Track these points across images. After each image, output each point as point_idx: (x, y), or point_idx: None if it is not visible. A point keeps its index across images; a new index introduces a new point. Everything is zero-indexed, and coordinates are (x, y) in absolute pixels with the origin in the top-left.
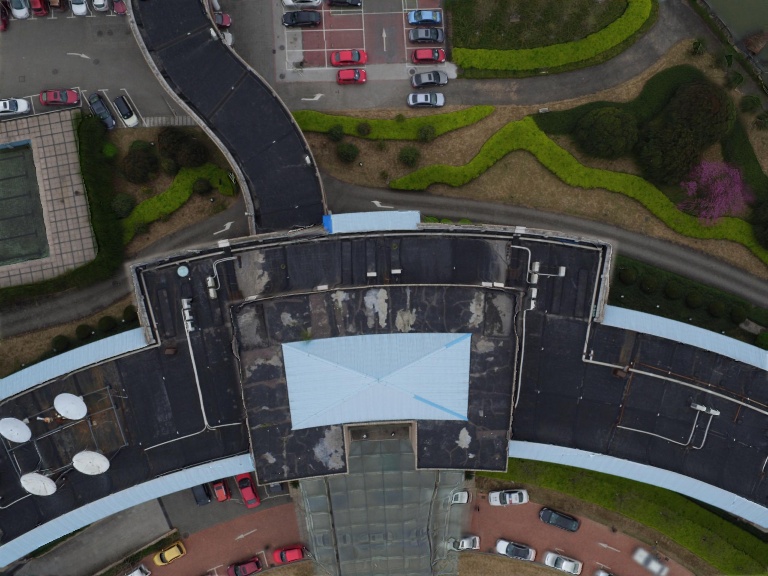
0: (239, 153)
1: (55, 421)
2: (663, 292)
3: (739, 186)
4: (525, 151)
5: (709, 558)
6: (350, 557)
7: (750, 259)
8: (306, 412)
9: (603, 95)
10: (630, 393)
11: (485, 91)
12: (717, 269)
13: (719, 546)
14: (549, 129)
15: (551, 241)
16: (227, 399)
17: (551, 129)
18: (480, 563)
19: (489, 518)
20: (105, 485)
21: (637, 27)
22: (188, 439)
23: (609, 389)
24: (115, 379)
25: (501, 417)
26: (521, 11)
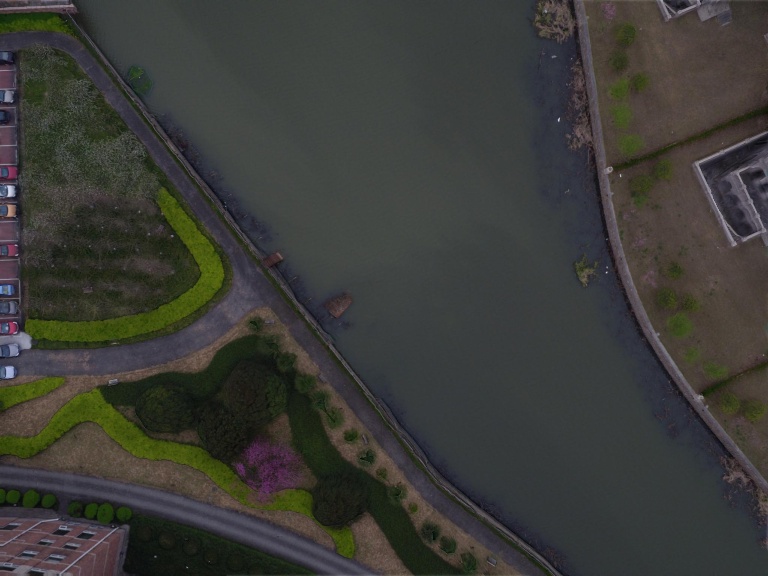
0: None
1: None
2: (226, 563)
3: (299, 461)
4: (94, 422)
5: None
6: None
7: (316, 529)
8: None
9: (174, 365)
10: None
11: (58, 361)
12: (283, 539)
13: None
14: (116, 402)
15: None
16: None
17: (117, 402)
18: None
19: None
20: None
21: (208, 298)
22: None
23: None
24: None
25: None
26: (95, 282)
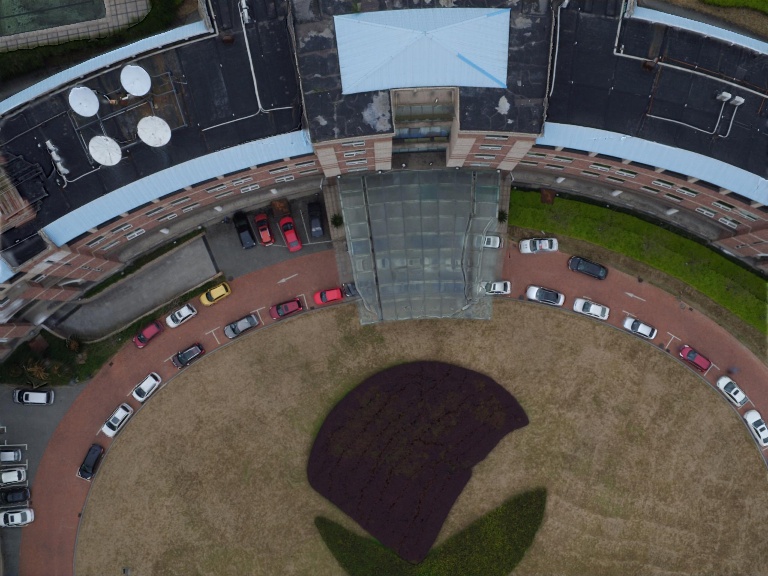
0: None
1: (119, 104)
2: None
3: None
4: None
5: (732, 307)
6: (388, 280)
7: None
8: (356, 75)
9: None
10: (659, 86)
11: None
12: None
13: (741, 296)
14: None
15: None
16: (280, 86)
17: None
18: (511, 309)
19: (520, 265)
20: (165, 163)
21: None
22: (243, 121)
23: (639, 82)
24: (176, 67)
25: (538, 87)
26: None
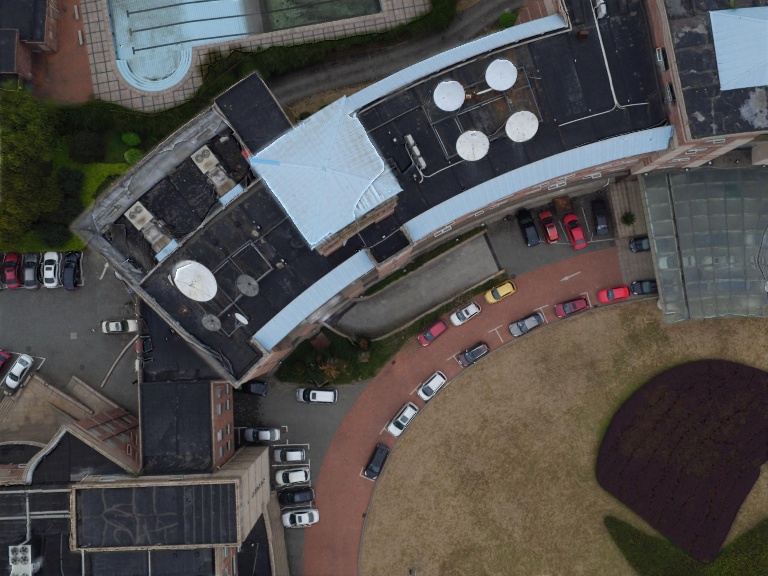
0: None
1: (473, 99)
2: None
3: None
4: None
5: None
6: (694, 278)
7: None
8: (737, 71)
9: None
10: None
11: None
12: None
13: None
14: None
15: None
16: (634, 81)
17: None
18: None
19: None
20: (521, 159)
21: None
22: (599, 117)
23: None
24: (528, 62)
25: None
26: None
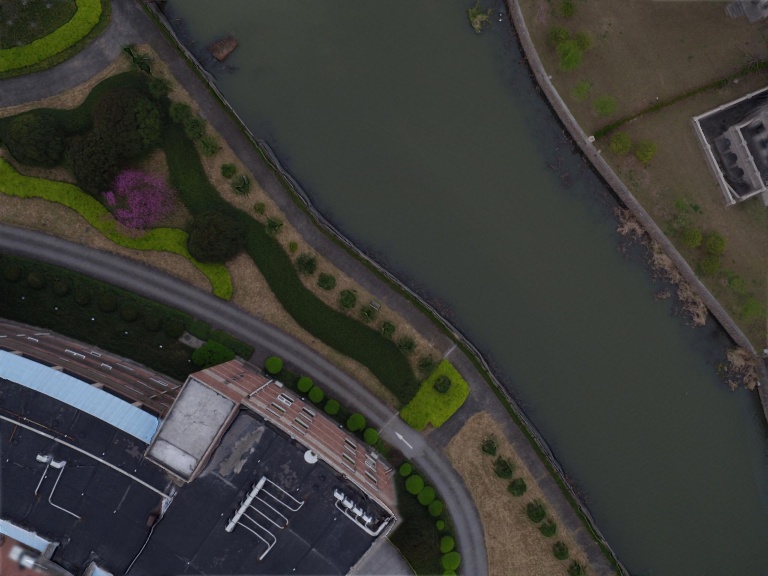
0: None
1: None
2: (98, 304)
3: (174, 196)
4: None
5: None
6: None
7: (194, 271)
8: None
9: (48, 102)
10: None
11: None
12: (159, 281)
13: None
14: None
15: None
16: None
17: None
18: None
19: None
20: None
21: (84, 32)
22: None
23: None
24: None
25: None
26: None
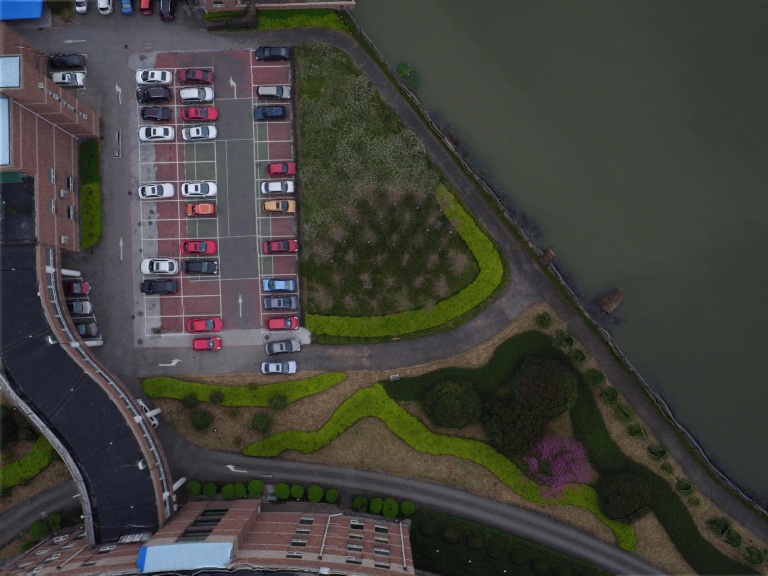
0: (78, 453)
1: None
2: (509, 557)
3: (584, 456)
4: (375, 417)
5: None
6: None
7: (597, 523)
8: None
9: (454, 360)
10: None
11: (338, 357)
12: (564, 533)
13: None
14: (399, 397)
15: (357, 575)
16: None
17: (401, 397)
18: None
19: None
20: None
21: (488, 294)
22: None
23: None
24: None
25: None
26: (374, 277)
